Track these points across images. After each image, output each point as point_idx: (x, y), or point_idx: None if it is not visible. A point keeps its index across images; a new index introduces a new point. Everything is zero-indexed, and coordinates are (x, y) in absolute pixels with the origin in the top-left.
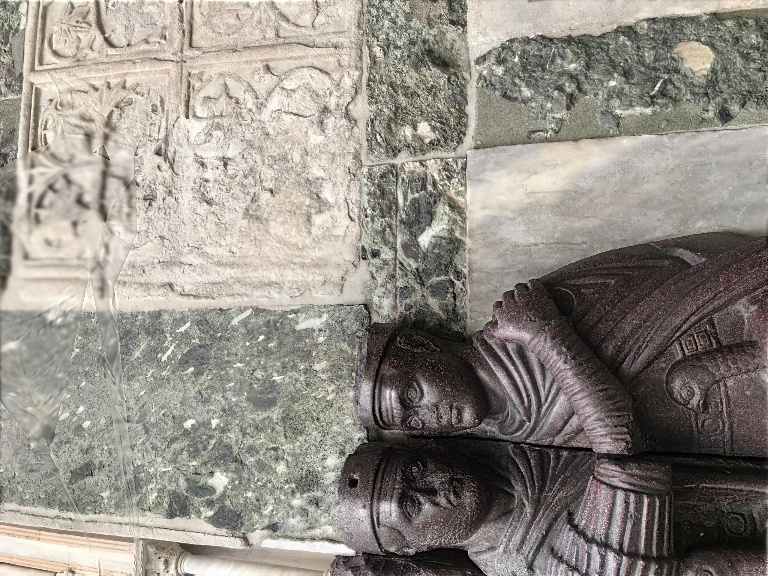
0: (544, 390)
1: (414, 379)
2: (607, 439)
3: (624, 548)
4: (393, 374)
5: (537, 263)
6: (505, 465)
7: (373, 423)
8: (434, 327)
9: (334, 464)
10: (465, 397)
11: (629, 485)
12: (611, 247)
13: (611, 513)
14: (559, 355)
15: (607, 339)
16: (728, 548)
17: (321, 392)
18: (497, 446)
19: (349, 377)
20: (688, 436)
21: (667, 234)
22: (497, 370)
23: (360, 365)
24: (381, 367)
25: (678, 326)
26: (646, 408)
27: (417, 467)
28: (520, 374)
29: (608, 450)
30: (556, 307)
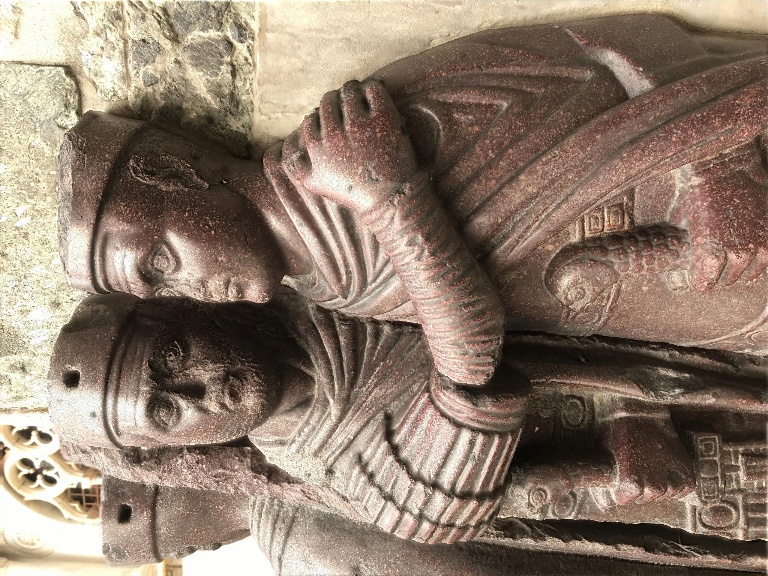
0: (374, 269)
1: (163, 241)
2: (462, 369)
3: (457, 488)
4: (125, 232)
5: (378, 29)
6: (303, 334)
7: (97, 293)
8: (197, 120)
9: (43, 318)
10: (250, 269)
11: (479, 423)
12: (499, 17)
13: (449, 452)
14: (411, 246)
15: (484, 212)
16: (567, 457)
17: (3, 213)
18: (291, 295)
19: (51, 193)
20: (550, 323)
21: (587, 6)
22: (303, 233)
23: (62, 208)
24: (101, 219)
25: (591, 203)
26: (511, 297)
27: (174, 352)
28: (340, 243)
29: (460, 380)
30: (413, 151)
